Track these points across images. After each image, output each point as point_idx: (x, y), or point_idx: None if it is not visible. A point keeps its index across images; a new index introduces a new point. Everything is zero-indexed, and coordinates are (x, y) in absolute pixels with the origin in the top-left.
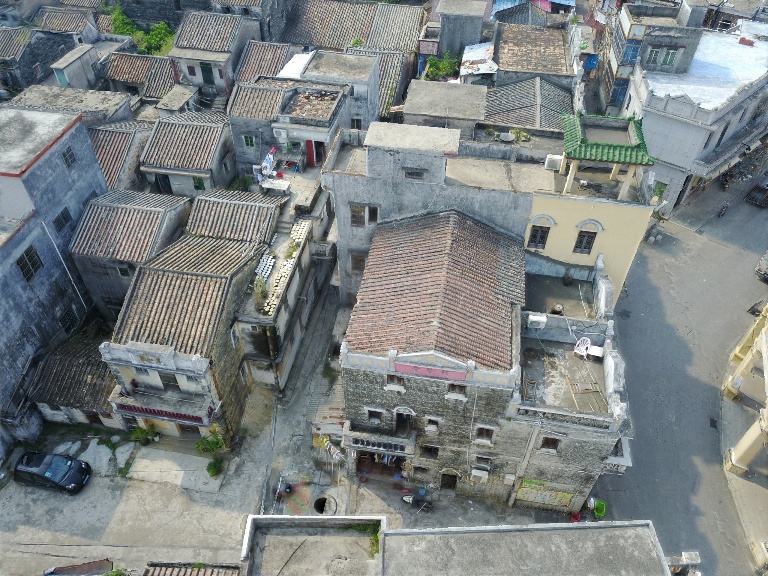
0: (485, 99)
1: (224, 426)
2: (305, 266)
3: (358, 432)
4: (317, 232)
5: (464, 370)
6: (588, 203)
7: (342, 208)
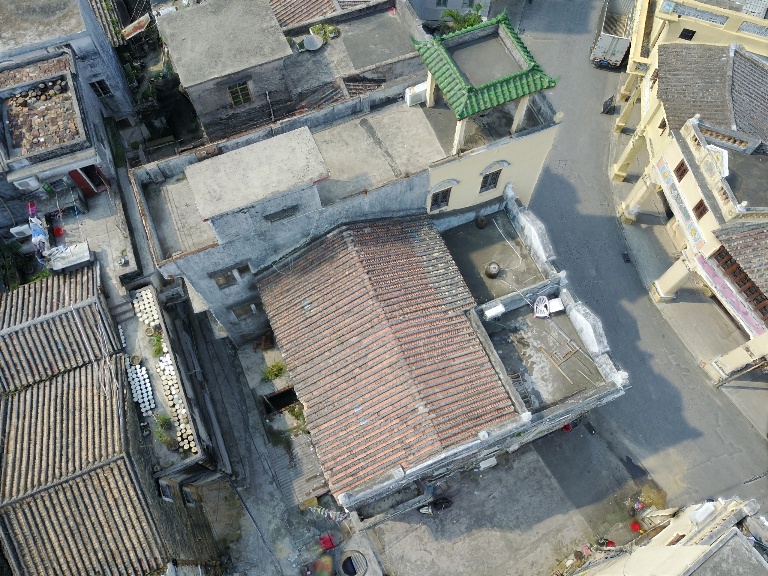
0: (273, 14)
1: (211, 571)
2: (171, 331)
3: (370, 517)
4: (155, 277)
5: (478, 445)
6: (491, 150)
7: (202, 282)
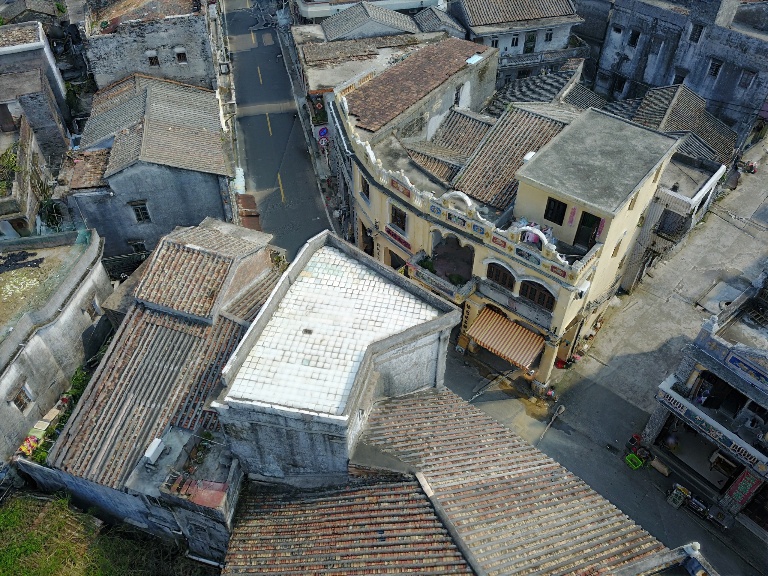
0: None
1: None
2: None
3: None
4: None
5: None
6: None
7: None
